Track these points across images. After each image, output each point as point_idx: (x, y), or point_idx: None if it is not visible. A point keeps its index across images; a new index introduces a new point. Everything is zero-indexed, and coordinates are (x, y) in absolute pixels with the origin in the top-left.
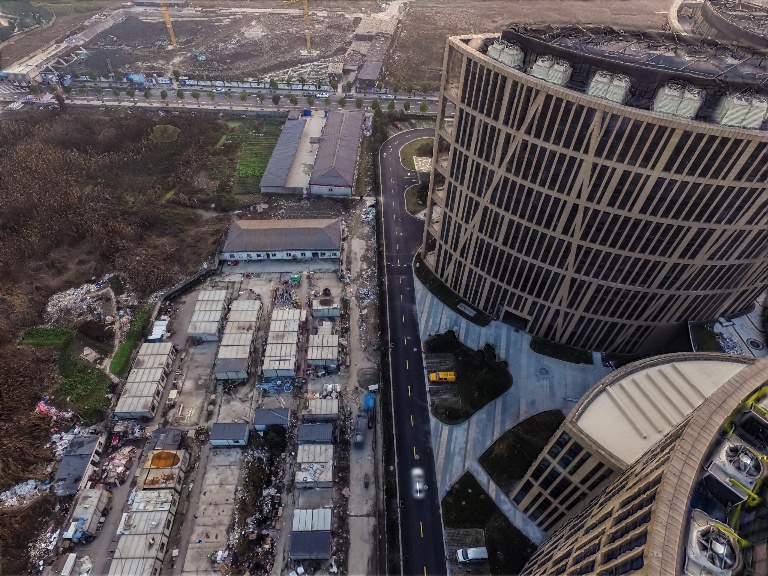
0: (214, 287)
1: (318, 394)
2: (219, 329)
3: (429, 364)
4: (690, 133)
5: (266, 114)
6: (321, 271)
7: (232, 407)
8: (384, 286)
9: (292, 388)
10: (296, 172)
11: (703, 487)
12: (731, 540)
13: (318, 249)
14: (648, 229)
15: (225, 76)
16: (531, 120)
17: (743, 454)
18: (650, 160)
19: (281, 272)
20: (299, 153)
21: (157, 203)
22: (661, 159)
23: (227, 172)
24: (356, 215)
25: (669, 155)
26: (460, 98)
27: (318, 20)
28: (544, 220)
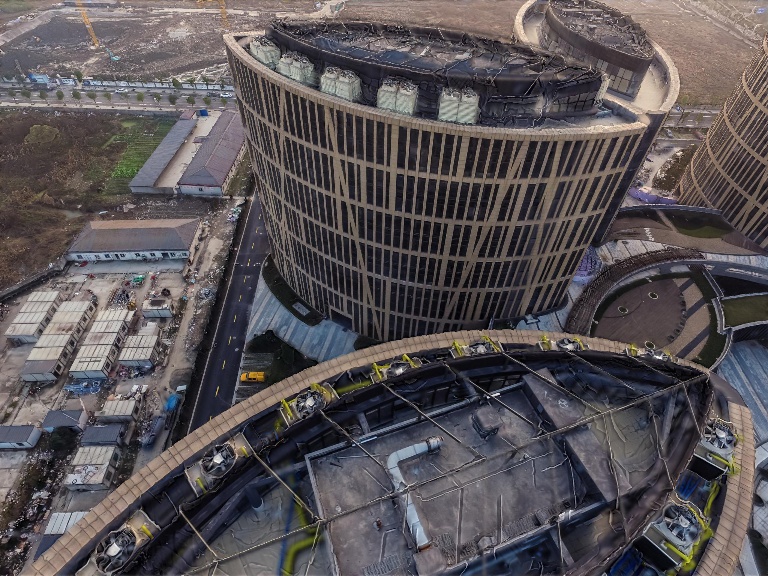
0: (54, 288)
1: (120, 395)
2: (41, 331)
3: (246, 364)
4: (406, 129)
5: (163, 114)
6: (168, 271)
7: (32, 409)
8: (226, 286)
9: (100, 389)
10: (174, 172)
11: (160, 488)
12: (136, 542)
13: (166, 249)
14: (410, 226)
15: (136, 76)
16: (284, 117)
17: (220, 453)
18: (383, 156)
19: (127, 273)
20: (183, 153)
21: (21, 204)
22: (391, 155)
23: (104, 172)
24: (222, 215)
25: (397, 151)
26: (241, 96)
27: (248, 20)
28: (326, 218)
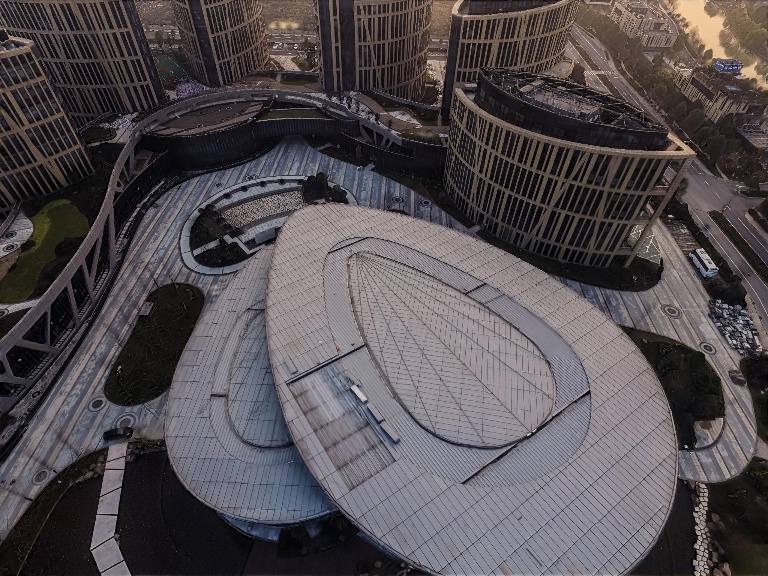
0: None
1: None
2: None
3: None
4: None
5: None
6: None
7: None
8: None
9: None
10: None
11: None
12: None
13: None
14: None
15: None
16: None
17: None
18: None
19: None
20: None
21: None
22: None
23: None
24: None
25: None
26: None
27: None
28: None
